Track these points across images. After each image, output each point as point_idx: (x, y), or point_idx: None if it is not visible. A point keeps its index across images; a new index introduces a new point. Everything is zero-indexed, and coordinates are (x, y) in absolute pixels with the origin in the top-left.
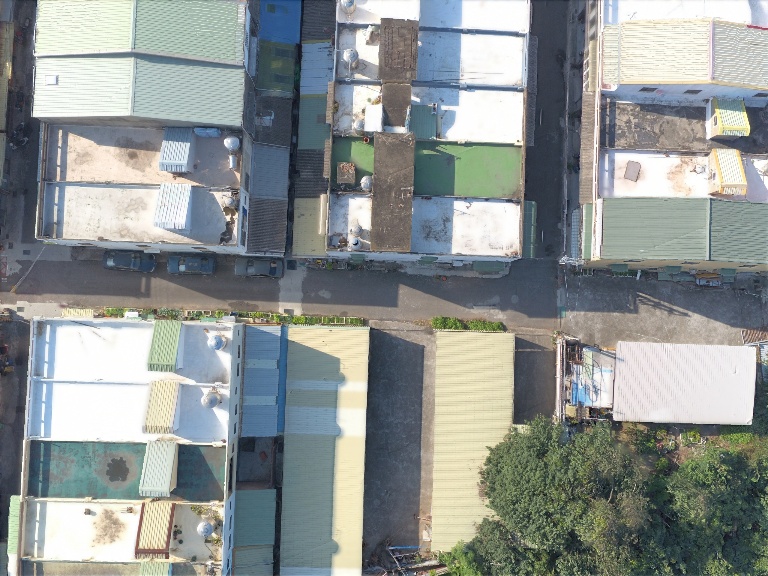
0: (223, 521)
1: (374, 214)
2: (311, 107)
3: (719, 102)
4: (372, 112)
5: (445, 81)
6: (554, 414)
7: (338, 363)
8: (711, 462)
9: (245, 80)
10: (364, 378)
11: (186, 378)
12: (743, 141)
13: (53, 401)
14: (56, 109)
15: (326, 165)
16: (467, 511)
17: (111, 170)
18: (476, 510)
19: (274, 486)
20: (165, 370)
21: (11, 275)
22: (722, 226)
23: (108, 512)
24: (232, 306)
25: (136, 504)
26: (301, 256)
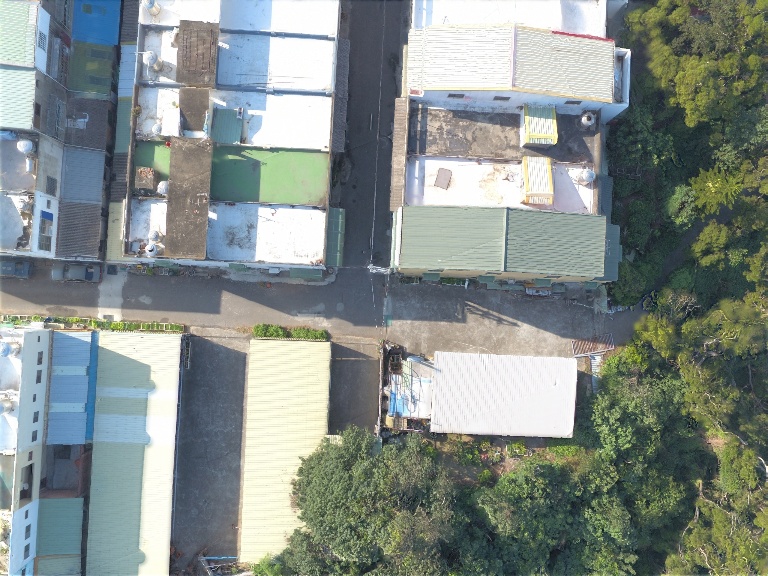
0: (11, 531)
1: (168, 220)
2: (128, 110)
3: (530, 109)
4: (170, 116)
5: (252, 85)
6: (377, 424)
7: (149, 370)
8: (528, 475)
9: (41, 82)
10: (175, 386)
11: None
12: (558, 149)
13: None
14: None
15: None
16: (278, 522)
17: None
18: (287, 521)
19: (84, 494)
20: None
21: None
22: (520, 236)
23: None
24: (50, 311)
25: None
26: (114, 261)
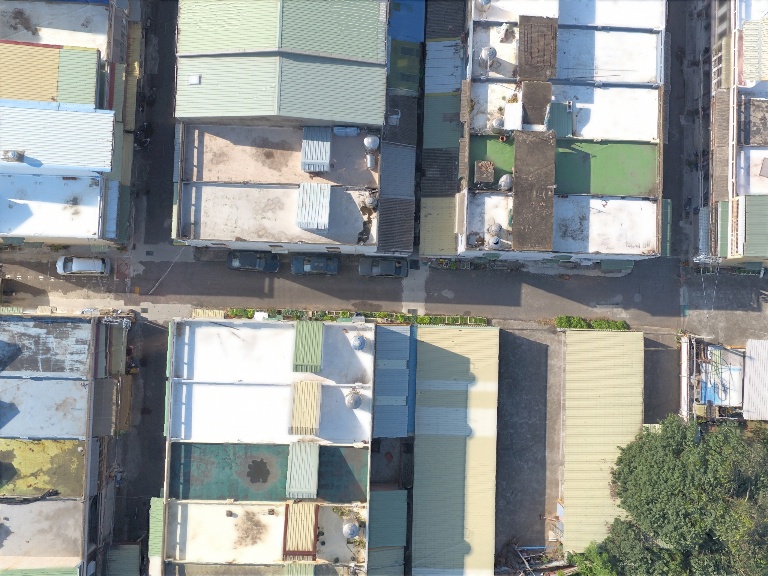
0: (366, 522)
1: (516, 213)
2: (437, 106)
3: None
4: (512, 110)
5: (580, 79)
6: (679, 413)
7: (468, 363)
8: None
9: None
10: (494, 378)
11: (326, 379)
12: None
13: (193, 402)
14: (199, 109)
15: (461, 164)
16: (599, 511)
17: (248, 170)
18: (608, 510)
19: (403, 487)
20: (310, 371)
21: (134, 276)
22: None
23: (249, 514)
24: (355, 306)
25: (278, 506)
26: (429, 255)
